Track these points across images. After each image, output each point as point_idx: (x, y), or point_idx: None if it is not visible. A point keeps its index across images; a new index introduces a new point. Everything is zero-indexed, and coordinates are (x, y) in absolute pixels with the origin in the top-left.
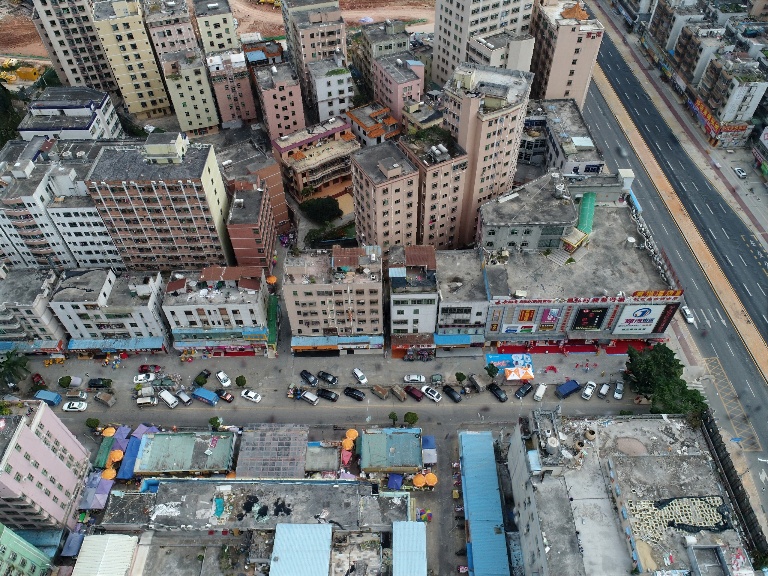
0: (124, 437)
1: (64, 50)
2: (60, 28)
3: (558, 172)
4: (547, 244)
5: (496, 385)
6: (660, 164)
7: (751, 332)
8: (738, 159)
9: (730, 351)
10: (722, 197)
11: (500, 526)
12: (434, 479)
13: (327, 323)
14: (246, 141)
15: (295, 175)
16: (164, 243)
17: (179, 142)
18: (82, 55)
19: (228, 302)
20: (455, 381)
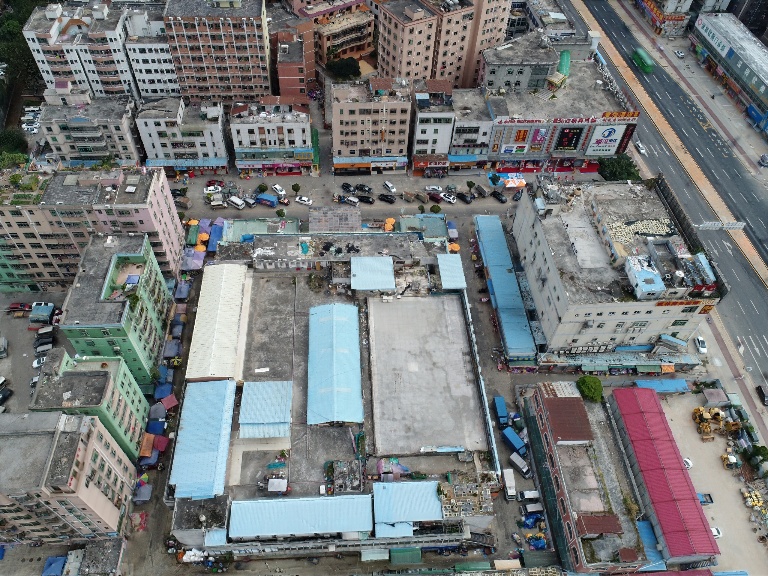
0: (207, 225)
1: None
2: None
3: None
4: (535, 84)
5: (498, 192)
6: (616, 47)
7: (688, 159)
8: (678, 45)
9: (672, 171)
10: (665, 71)
11: (511, 268)
12: (458, 246)
13: (363, 144)
14: (279, 7)
15: (320, 39)
16: (221, 82)
17: None
18: None
19: (285, 122)
20: (465, 190)
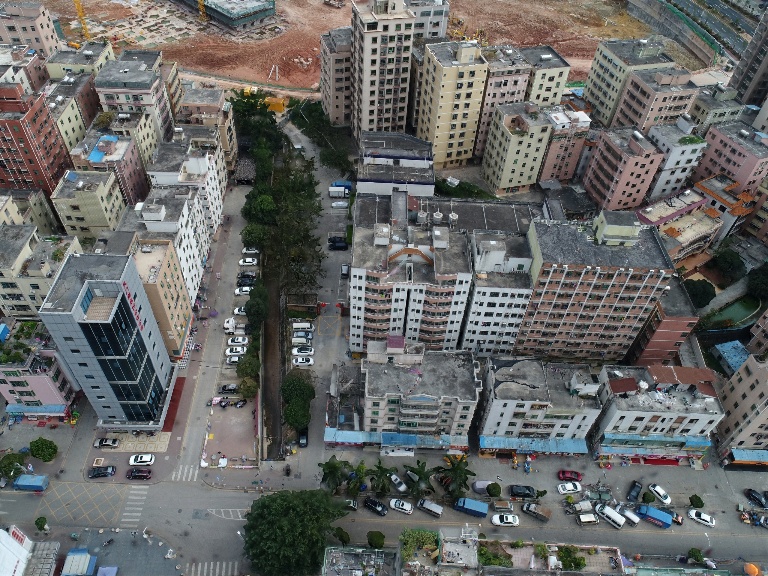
0: None
1: (372, 90)
2: (378, 67)
3: None
4: None
5: None
6: None
7: None
8: None
9: None
10: None
11: None
12: None
13: None
14: None
15: None
16: (576, 329)
17: None
18: (386, 96)
19: (689, 410)
20: None
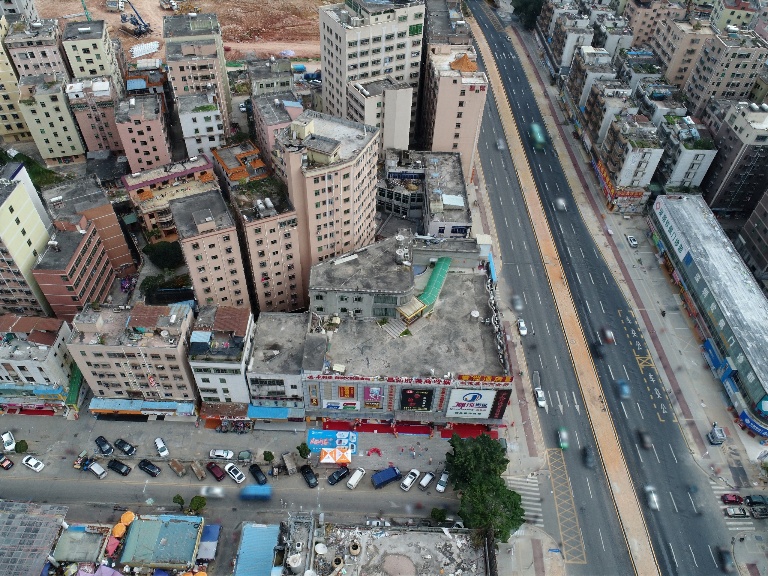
0: None
1: None
2: None
3: (408, 234)
4: (383, 313)
5: (309, 467)
6: (551, 226)
7: (604, 421)
8: (634, 226)
9: (577, 442)
10: (608, 266)
11: None
12: None
13: (129, 386)
14: (89, 176)
15: None
16: None
17: None
18: None
19: (13, 357)
20: None
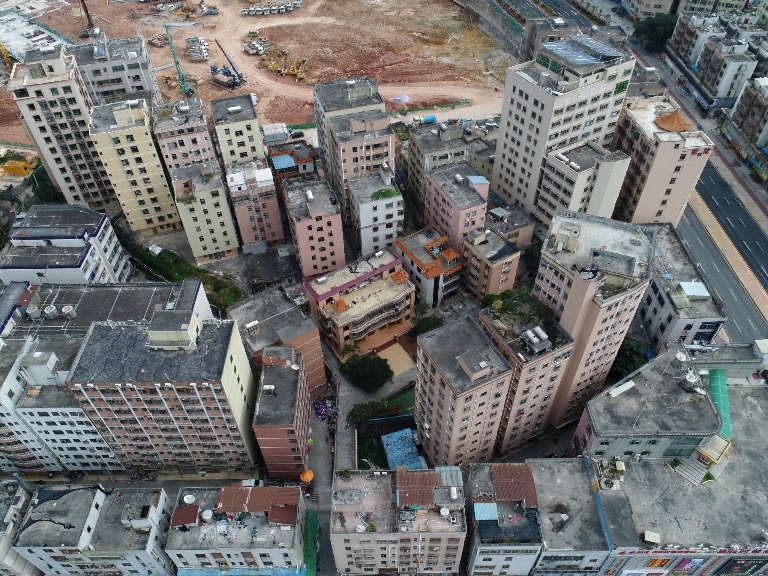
0: None
1: (56, 158)
2: (51, 134)
3: (680, 347)
4: (675, 453)
5: None
6: None
7: None
8: None
9: None
10: None
11: None
12: None
13: (385, 564)
14: (275, 288)
15: (335, 327)
16: (170, 441)
17: (193, 324)
18: (77, 162)
19: (254, 544)
20: None
